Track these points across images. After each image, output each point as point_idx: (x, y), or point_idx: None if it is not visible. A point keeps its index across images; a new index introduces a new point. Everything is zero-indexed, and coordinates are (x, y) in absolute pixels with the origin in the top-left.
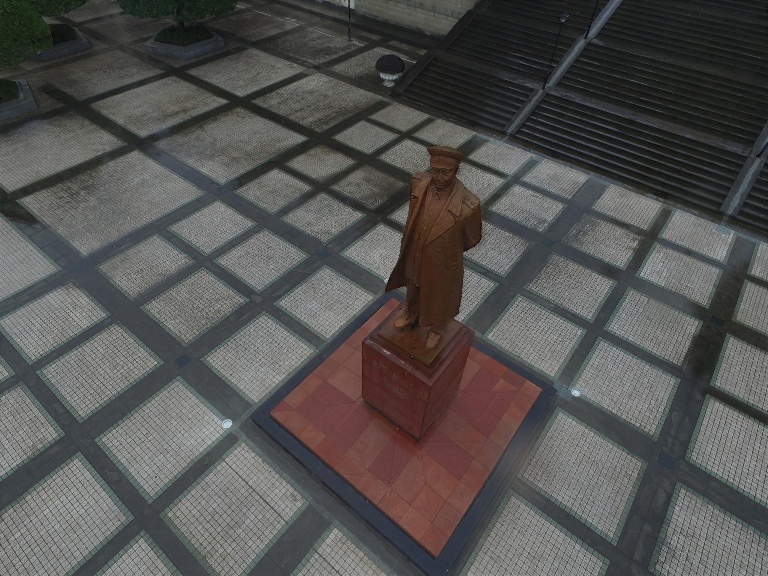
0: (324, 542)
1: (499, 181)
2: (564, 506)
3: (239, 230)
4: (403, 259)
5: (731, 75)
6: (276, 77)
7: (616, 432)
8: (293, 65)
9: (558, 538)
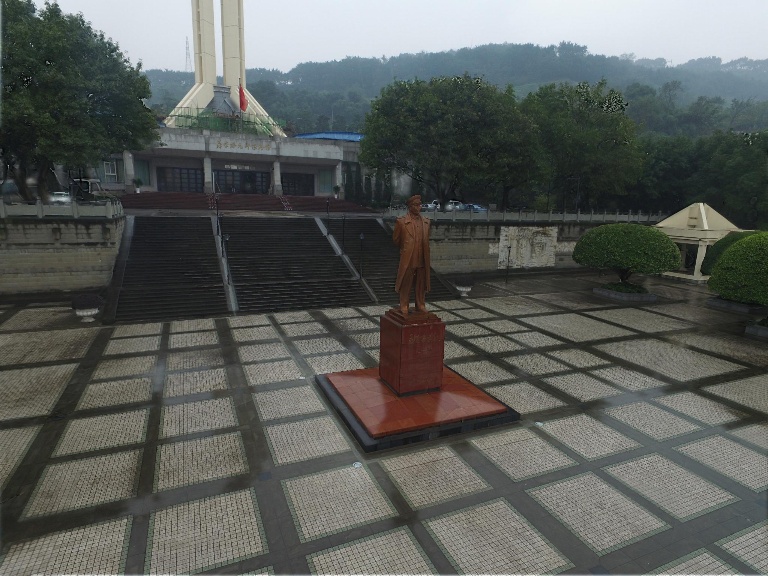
0: (477, 446)
1: (270, 327)
2: (496, 381)
3: (140, 418)
4: (412, 257)
5: (313, 255)
6: None
7: None
8: None
9: (510, 387)
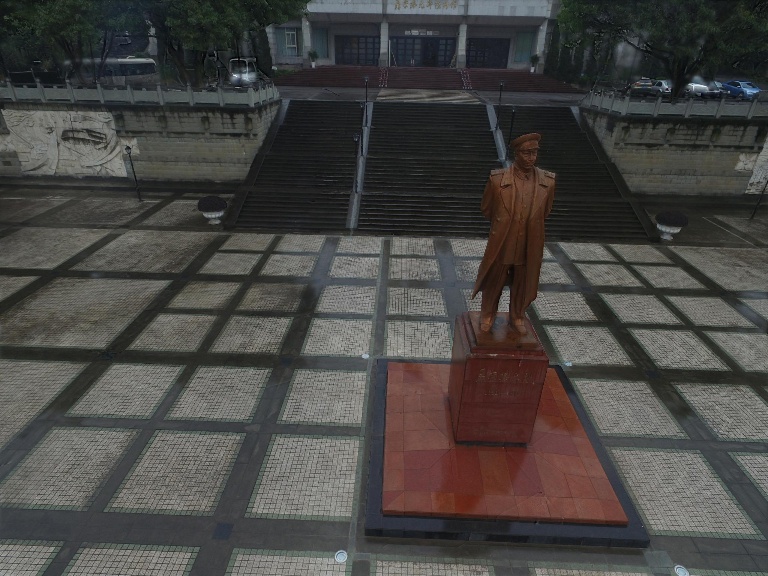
0: None
1: (376, 260)
2: (643, 435)
3: (169, 379)
4: (503, 247)
5: (467, 159)
6: (82, 244)
7: (614, 374)
8: (94, 230)
9: (663, 457)
